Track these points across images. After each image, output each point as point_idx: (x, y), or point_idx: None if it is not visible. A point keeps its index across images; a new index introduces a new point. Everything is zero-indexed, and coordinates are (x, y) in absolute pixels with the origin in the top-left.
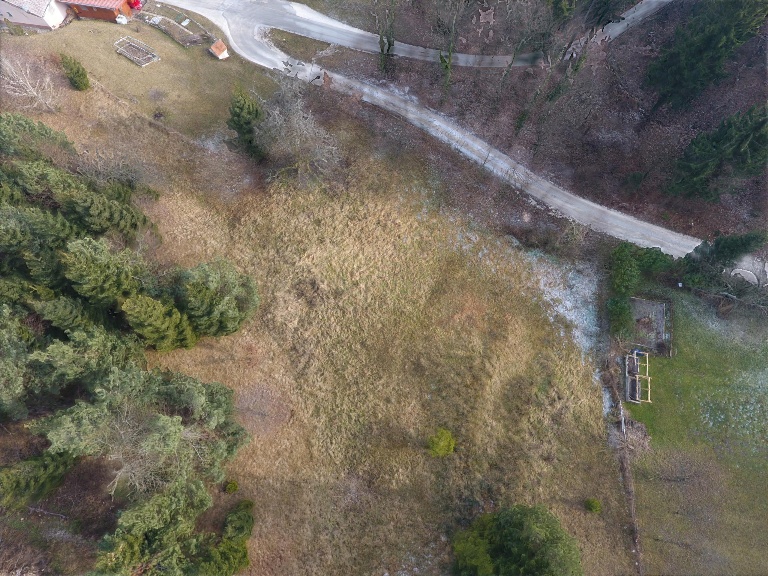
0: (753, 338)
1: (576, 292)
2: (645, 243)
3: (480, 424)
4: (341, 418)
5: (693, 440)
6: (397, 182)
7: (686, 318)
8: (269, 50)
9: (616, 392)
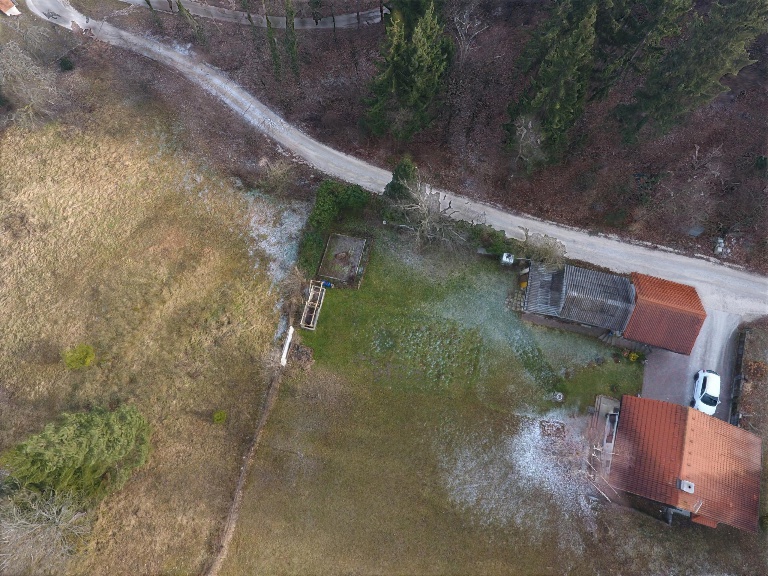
0: (441, 271)
1: (284, 229)
2: (371, 186)
3: (137, 344)
4: (7, 338)
5: (357, 364)
6: (138, 127)
7: (383, 253)
8: (64, 9)
9: (289, 319)
